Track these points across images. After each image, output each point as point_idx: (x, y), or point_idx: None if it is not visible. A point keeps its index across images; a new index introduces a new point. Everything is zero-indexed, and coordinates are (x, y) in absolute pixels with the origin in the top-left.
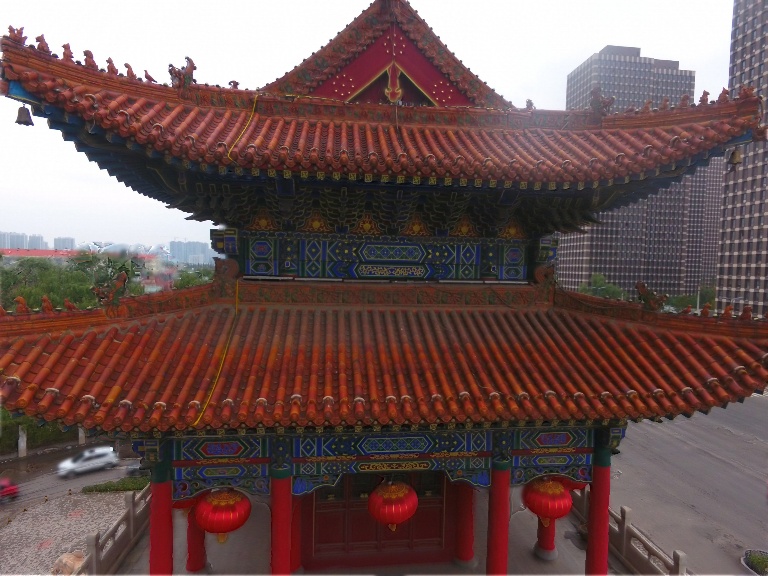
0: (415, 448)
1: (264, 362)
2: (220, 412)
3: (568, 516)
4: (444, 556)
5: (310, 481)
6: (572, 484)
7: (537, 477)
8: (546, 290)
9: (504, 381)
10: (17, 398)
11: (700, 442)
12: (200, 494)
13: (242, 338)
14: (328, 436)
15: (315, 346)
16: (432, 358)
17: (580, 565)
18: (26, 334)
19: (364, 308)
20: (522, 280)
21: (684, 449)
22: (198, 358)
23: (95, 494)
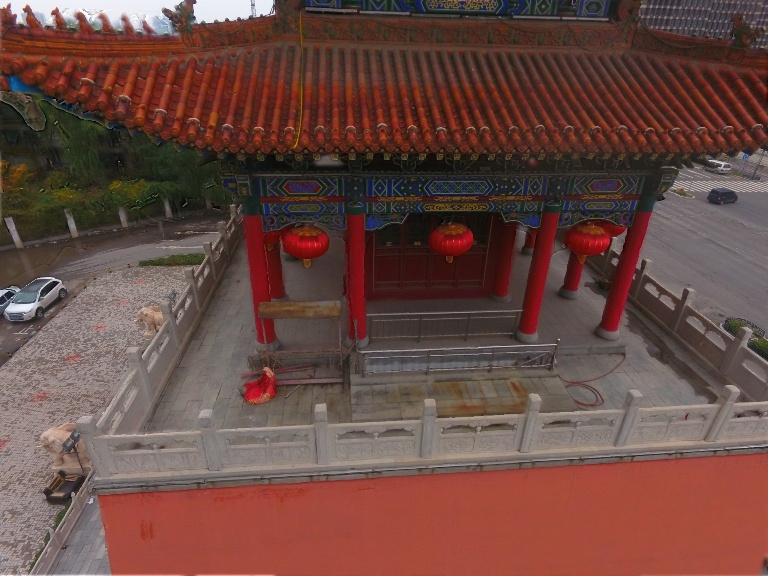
0: (476, 191)
1: (342, 98)
2: (314, 138)
3: (589, 272)
4: (483, 294)
5: (381, 219)
6: (610, 231)
7: (582, 221)
8: (627, 29)
9: (577, 118)
10: (133, 116)
11: (710, 233)
12: (286, 228)
13: (314, 76)
14: (398, 178)
15: (389, 84)
16: (505, 97)
17: (596, 304)
18: (118, 56)
19: (432, 48)
20: (602, 17)
21: (693, 239)
22: (278, 92)
23: (151, 268)
